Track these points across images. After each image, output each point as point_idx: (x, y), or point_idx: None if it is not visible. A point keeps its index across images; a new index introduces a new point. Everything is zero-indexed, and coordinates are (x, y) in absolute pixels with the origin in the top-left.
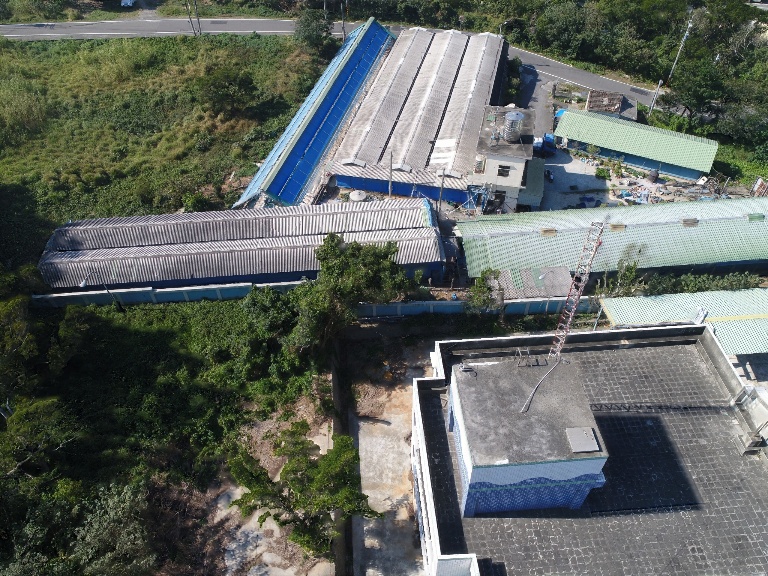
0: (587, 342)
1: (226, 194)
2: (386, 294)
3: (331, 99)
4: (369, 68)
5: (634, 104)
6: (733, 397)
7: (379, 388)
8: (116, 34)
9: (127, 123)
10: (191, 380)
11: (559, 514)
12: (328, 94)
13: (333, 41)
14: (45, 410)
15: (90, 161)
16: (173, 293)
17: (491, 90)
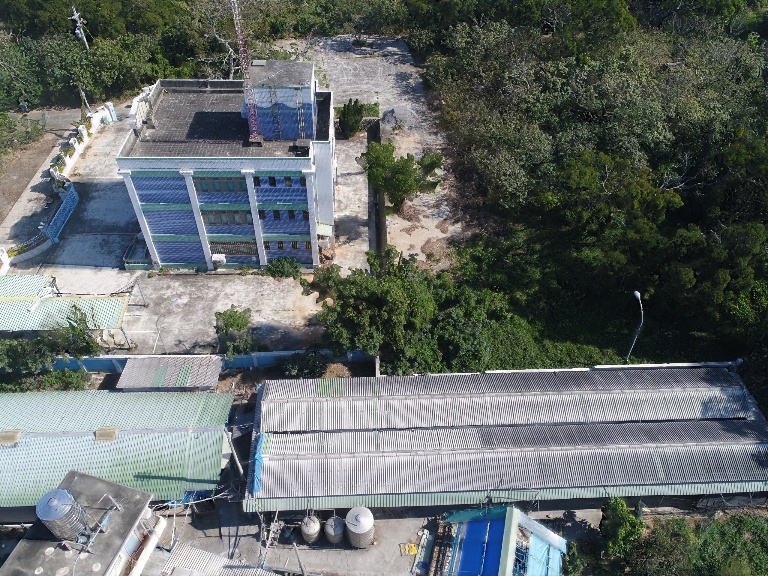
0: None
1: None
2: None
3: None
4: None
5: None
6: (138, 137)
7: None
8: None
9: None
10: (512, 296)
11: None
12: None
13: None
14: None
15: None
16: None
17: None
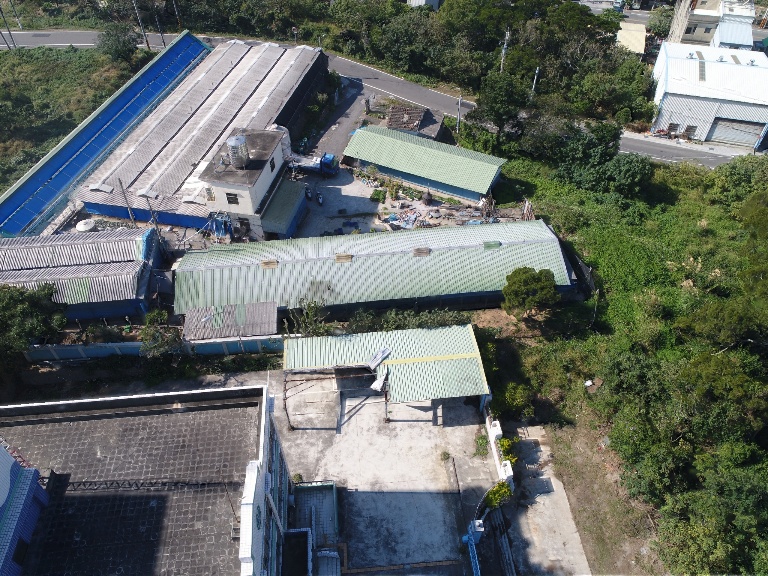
0: (135, 406)
1: None
2: None
3: (105, 119)
4: (168, 84)
5: (439, 120)
6: None
7: None
8: None
9: None
10: None
11: None
12: (102, 114)
13: (148, 55)
14: None
15: None
16: None
17: (282, 107)
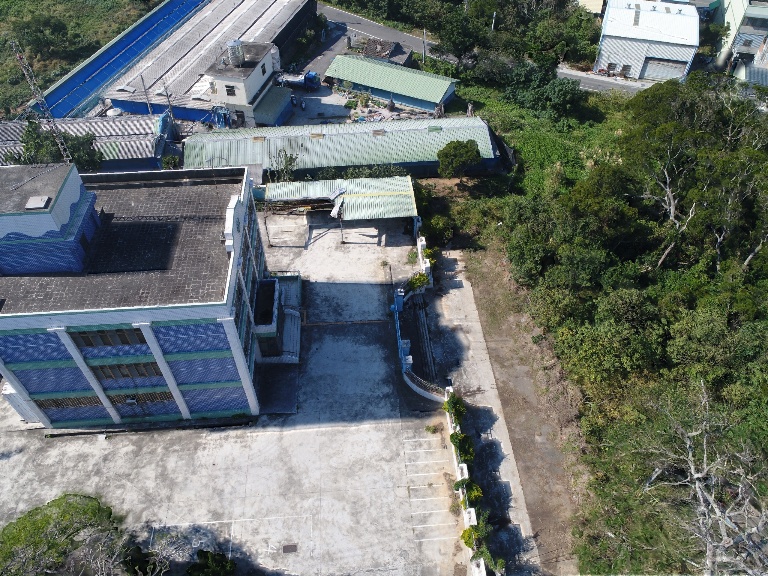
0: (158, 180)
1: None
2: None
3: (128, 41)
4: (180, 19)
5: (407, 52)
6: None
7: None
8: None
9: None
10: None
11: (64, 275)
12: (126, 37)
13: None
14: None
15: None
16: None
17: (275, 36)
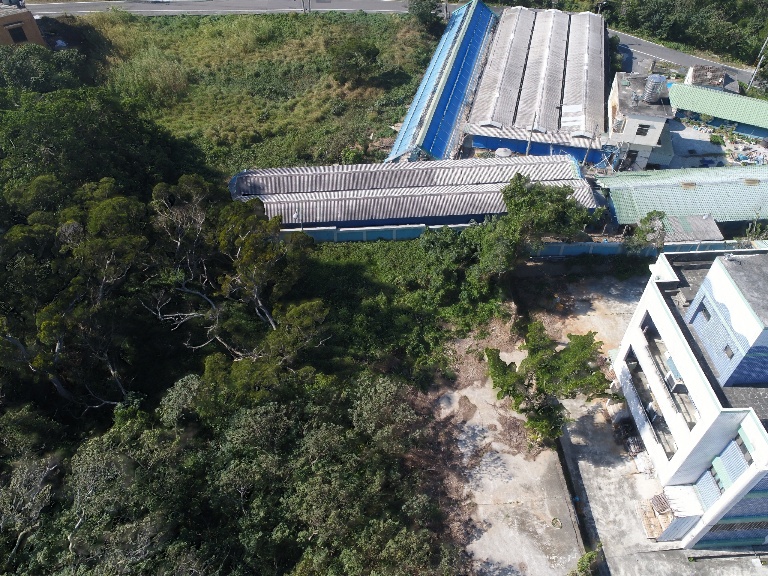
0: None
1: (371, 152)
2: (570, 228)
3: (456, 69)
4: (481, 43)
5: (735, 79)
6: None
7: (553, 317)
8: (229, 11)
9: (261, 90)
10: (389, 305)
11: None
12: (454, 64)
13: (438, 19)
14: (318, 308)
15: (241, 121)
16: (354, 232)
17: (603, 63)
